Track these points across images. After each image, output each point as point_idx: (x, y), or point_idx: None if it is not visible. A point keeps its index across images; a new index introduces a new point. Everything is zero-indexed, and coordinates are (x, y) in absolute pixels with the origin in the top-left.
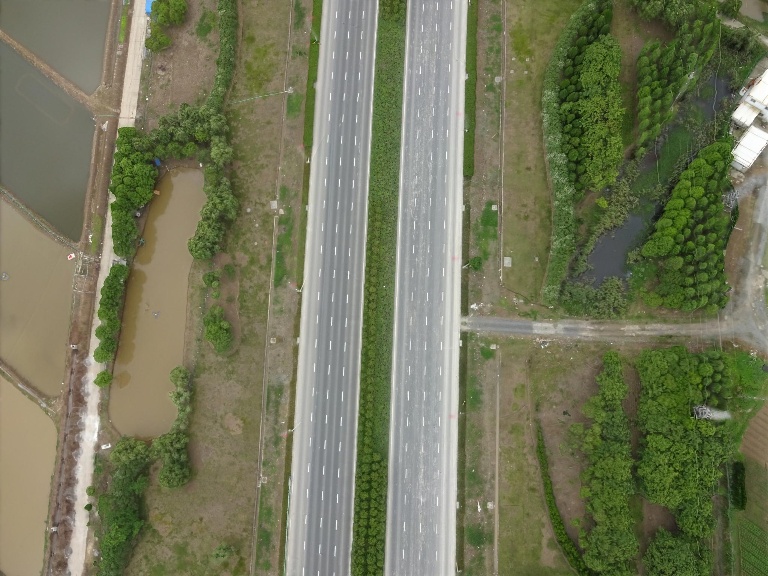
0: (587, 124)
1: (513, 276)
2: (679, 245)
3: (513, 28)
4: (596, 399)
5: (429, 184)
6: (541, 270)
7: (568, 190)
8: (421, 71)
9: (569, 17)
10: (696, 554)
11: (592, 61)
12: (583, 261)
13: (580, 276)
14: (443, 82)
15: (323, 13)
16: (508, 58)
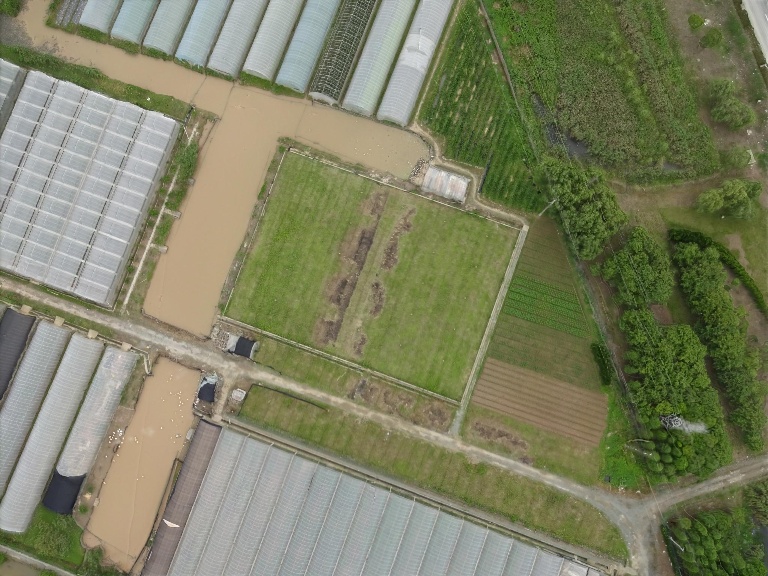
0: None
1: None
2: None
3: None
4: (762, 400)
5: None
6: None
7: None
8: None
9: None
10: (636, 295)
11: None
12: None
13: None
14: None
15: None
16: None
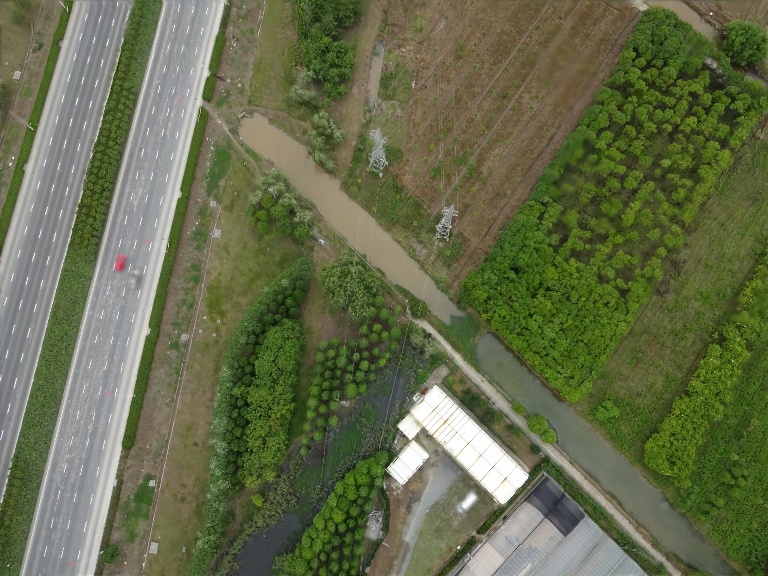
0: (251, 417)
1: (156, 565)
2: (312, 570)
3: (211, 282)
4: None
5: (84, 448)
6: (186, 563)
7: (222, 484)
8: (102, 315)
9: (268, 283)
10: None
11: (268, 349)
12: (227, 562)
13: (223, 575)
14: (124, 332)
15: (11, 225)
16: (200, 315)
